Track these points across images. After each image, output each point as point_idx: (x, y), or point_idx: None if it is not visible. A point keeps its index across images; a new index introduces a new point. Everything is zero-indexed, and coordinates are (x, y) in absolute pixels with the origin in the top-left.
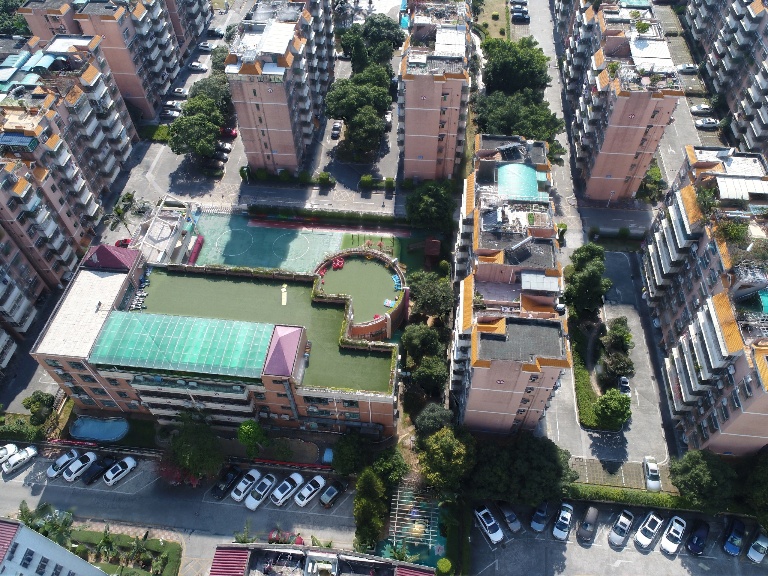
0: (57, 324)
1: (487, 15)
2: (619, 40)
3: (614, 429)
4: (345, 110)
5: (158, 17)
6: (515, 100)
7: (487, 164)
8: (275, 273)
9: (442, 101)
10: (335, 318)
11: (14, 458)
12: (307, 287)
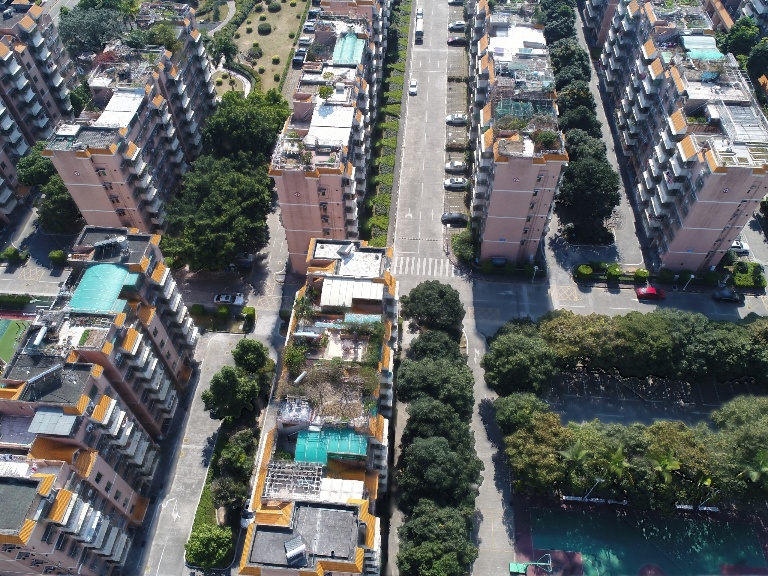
0: None
1: (268, 59)
2: (306, 105)
3: (221, 566)
4: (35, 178)
5: None
6: (221, 166)
7: (77, 264)
8: None
9: (102, 176)
10: None
11: None
12: None
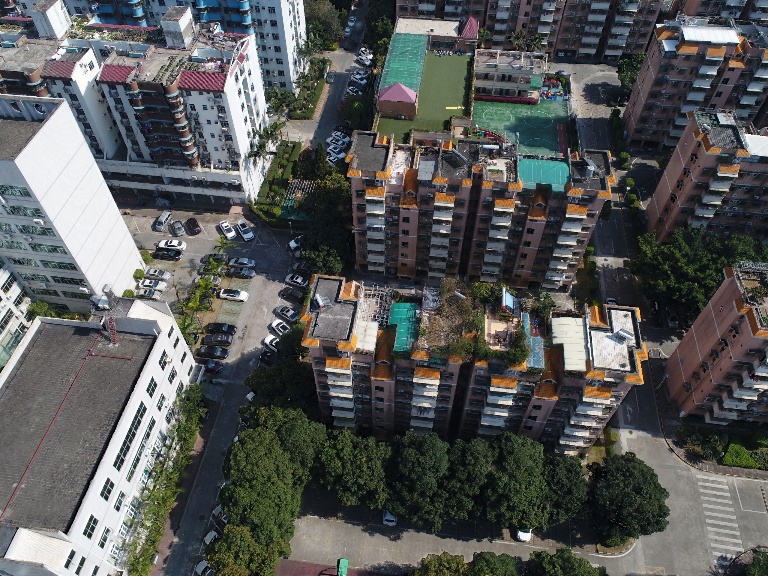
0: (418, 21)
1: None
2: None
3: None
4: None
5: (760, 7)
6: None
7: None
8: None
9: (693, 162)
10: None
11: (364, 58)
12: None
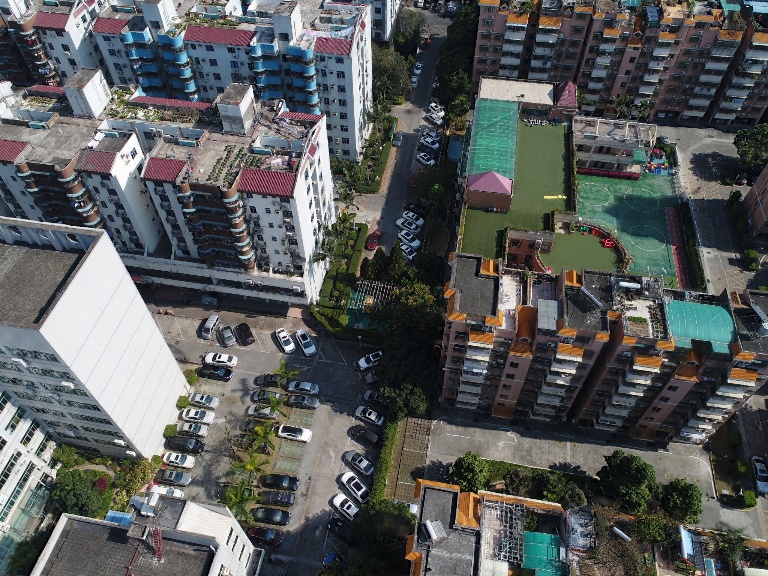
0: (505, 82)
1: None
2: None
3: None
4: None
5: None
6: None
7: None
8: (575, 188)
9: None
10: (534, 228)
11: (435, 115)
12: (565, 210)
